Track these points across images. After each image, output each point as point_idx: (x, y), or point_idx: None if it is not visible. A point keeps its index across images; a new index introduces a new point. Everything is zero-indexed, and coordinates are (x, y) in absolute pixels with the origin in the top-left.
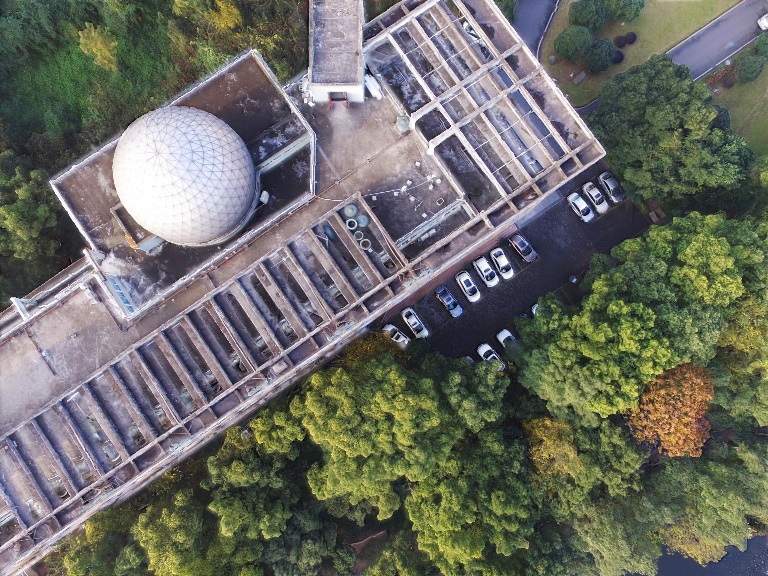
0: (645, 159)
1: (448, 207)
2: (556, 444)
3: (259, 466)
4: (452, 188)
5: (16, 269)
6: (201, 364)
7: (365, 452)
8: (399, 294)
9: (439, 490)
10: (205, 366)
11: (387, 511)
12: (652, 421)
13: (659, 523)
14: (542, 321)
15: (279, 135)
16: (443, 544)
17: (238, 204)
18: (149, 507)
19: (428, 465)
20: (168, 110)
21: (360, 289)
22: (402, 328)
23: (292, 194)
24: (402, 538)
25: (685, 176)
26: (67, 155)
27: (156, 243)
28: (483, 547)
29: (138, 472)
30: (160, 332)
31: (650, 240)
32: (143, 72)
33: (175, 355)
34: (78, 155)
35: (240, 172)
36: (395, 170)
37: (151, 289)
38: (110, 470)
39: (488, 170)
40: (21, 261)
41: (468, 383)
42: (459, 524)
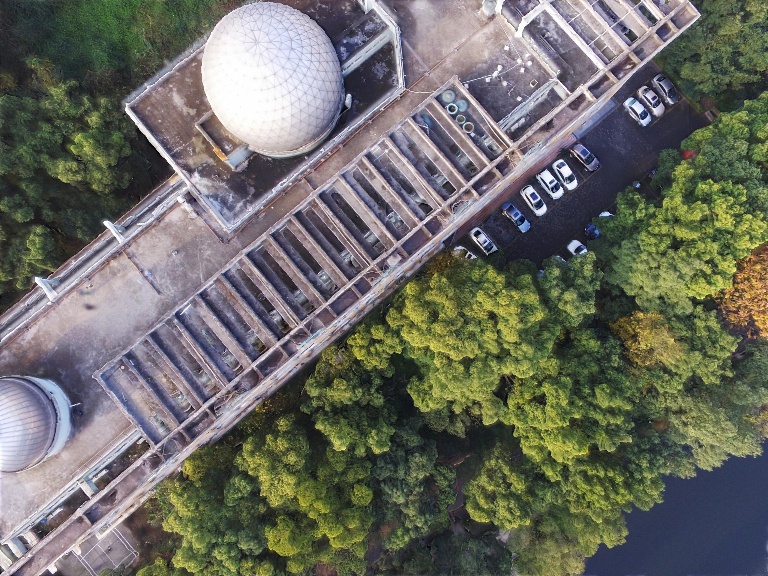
0: (704, 51)
1: (543, 87)
2: (654, 332)
3: (359, 384)
4: (544, 69)
5: (92, 206)
6: (311, 267)
7: (472, 352)
8: (508, 174)
9: (540, 391)
10: (315, 269)
11: (493, 415)
12: (748, 299)
13: (755, 406)
14: (628, 212)
15: (359, 34)
16: (553, 440)
17: (332, 100)
18: (249, 438)
19: (535, 360)
20: (257, 4)
21: (466, 174)
22: (471, 249)
23: (375, 97)
24: (501, 449)
25: (747, 63)
26: (124, 92)
27: (242, 157)
28: (589, 443)
29: (262, 378)
30: (268, 235)
31: (723, 125)
32: (189, 5)
33: (287, 257)
34: (136, 91)
35: (333, 65)
36: (484, 56)
37: (241, 206)
38: (233, 378)
39: (584, 42)
40: (96, 197)
41: (563, 278)
42: (567, 419)
